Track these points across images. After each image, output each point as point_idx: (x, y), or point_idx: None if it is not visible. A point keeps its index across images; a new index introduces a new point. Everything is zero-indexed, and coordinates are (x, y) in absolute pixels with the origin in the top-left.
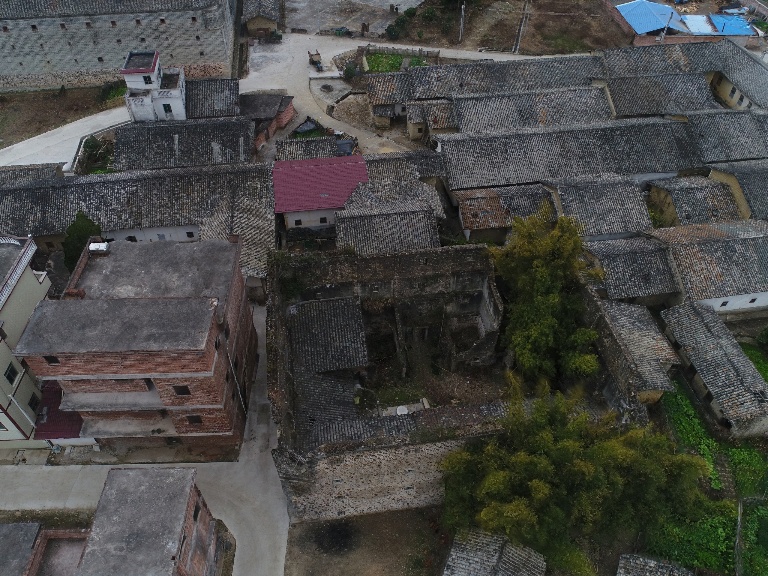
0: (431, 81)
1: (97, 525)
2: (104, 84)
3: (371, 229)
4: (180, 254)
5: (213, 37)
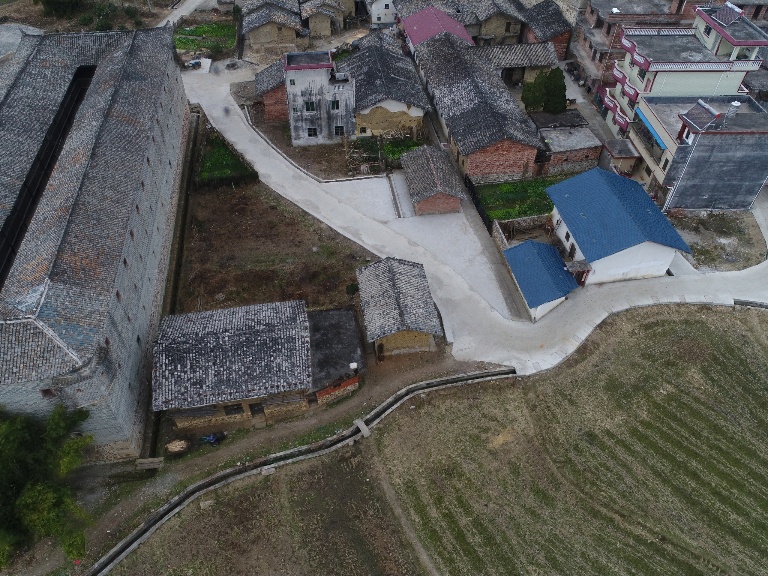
0: (283, 0)
1: (754, 2)
2: (199, 182)
3: (502, 6)
4: (602, 0)
5: (178, 73)
